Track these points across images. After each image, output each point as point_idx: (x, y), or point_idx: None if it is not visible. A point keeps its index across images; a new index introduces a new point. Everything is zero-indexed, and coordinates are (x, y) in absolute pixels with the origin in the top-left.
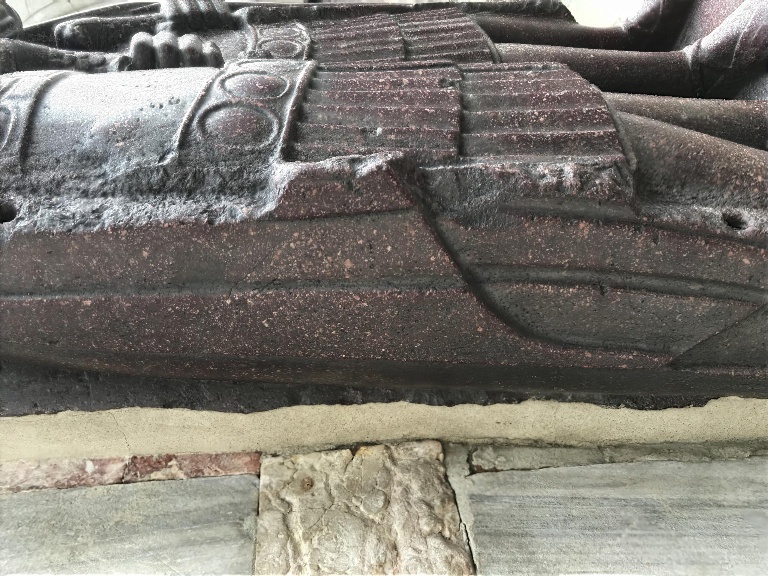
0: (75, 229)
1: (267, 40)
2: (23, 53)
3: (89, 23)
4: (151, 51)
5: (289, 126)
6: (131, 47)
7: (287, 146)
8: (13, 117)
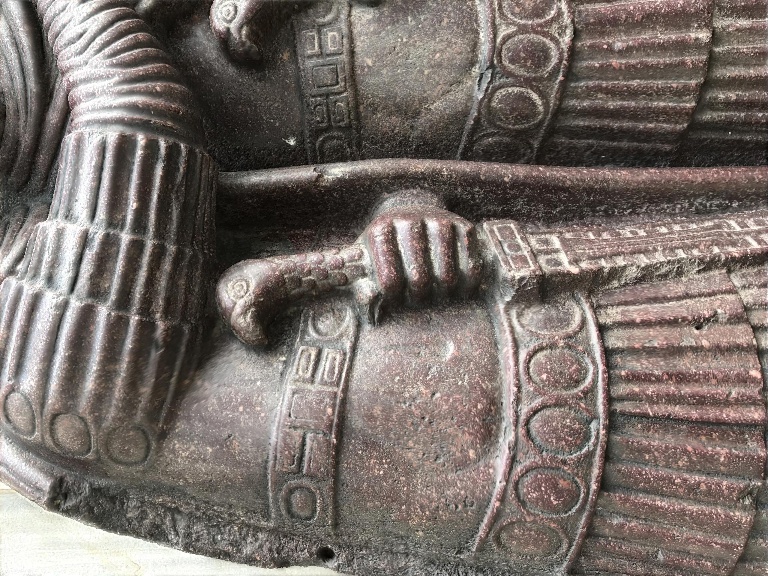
0: (386, 575)
1: (510, 35)
2: (265, 309)
3: (256, 11)
4: (403, 284)
5: (578, 548)
6: (379, 279)
7: (572, 563)
8: (318, 498)
